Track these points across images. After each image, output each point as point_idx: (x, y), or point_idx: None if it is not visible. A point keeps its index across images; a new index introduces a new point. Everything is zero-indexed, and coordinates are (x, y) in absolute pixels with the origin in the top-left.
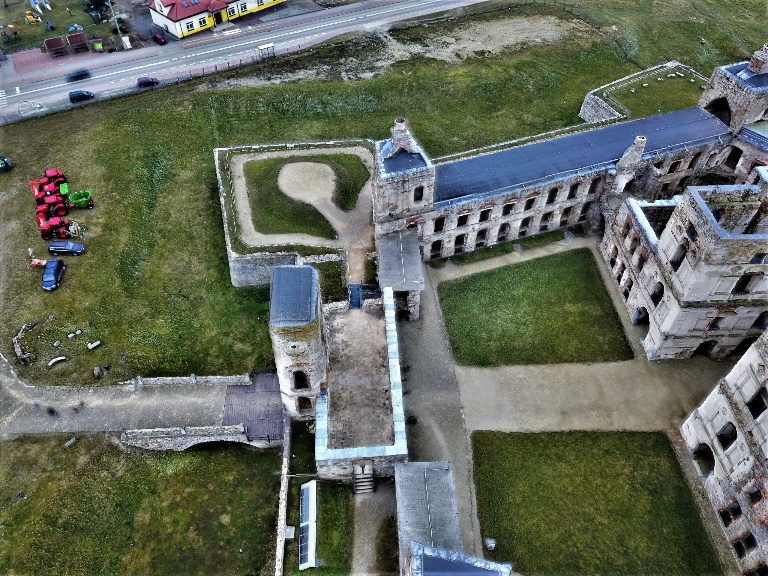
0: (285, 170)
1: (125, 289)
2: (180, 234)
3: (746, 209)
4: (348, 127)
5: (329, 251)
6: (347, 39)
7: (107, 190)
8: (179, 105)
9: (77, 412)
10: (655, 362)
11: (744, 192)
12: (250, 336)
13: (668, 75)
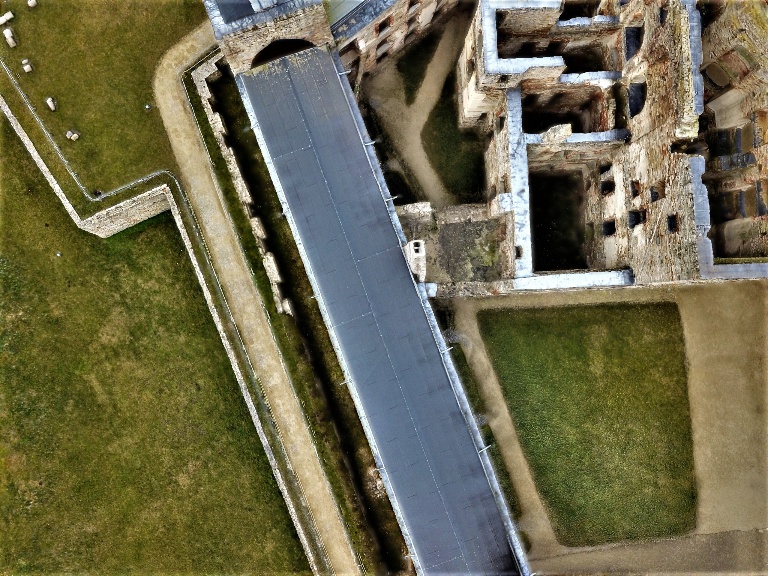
0: None
1: None
2: None
3: None
4: None
5: None
6: None
7: None
8: None
9: None
10: None
11: None
12: None
13: (11, 45)
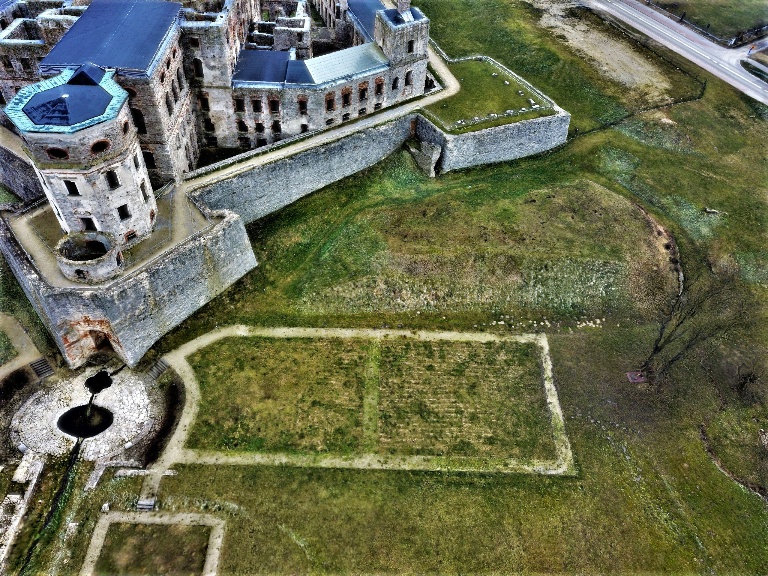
0: None
1: None
2: None
3: None
4: None
5: None
6: None
7: None
8: None
9: None
10: None
11: None
12: None
13: None
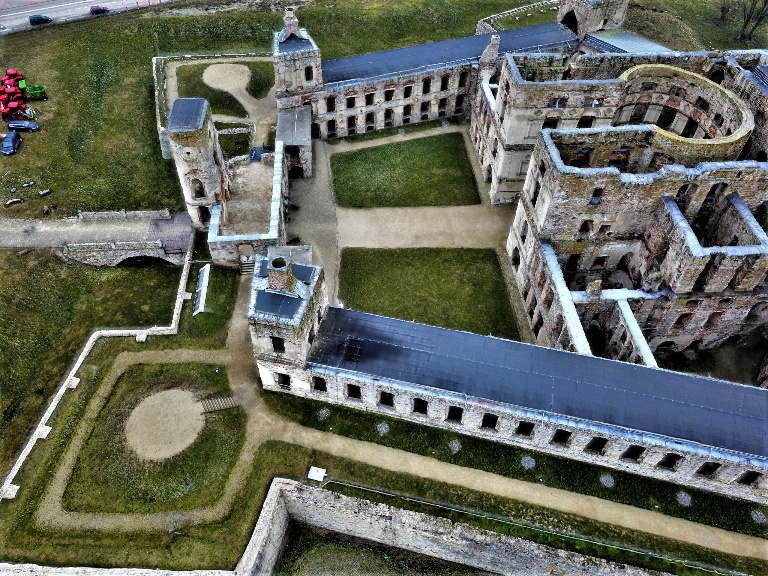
0: (209, 69)
1: (72, 156)
2: (121, 122)
3: (553, 73)
4: None
5: (241, 126)
6: None
7: (60, 88)
8: (126, 28)
9: (29, 235)
10: (497, 206)
11: (550, 59)
12: (175, 194)
13: (550, 8)
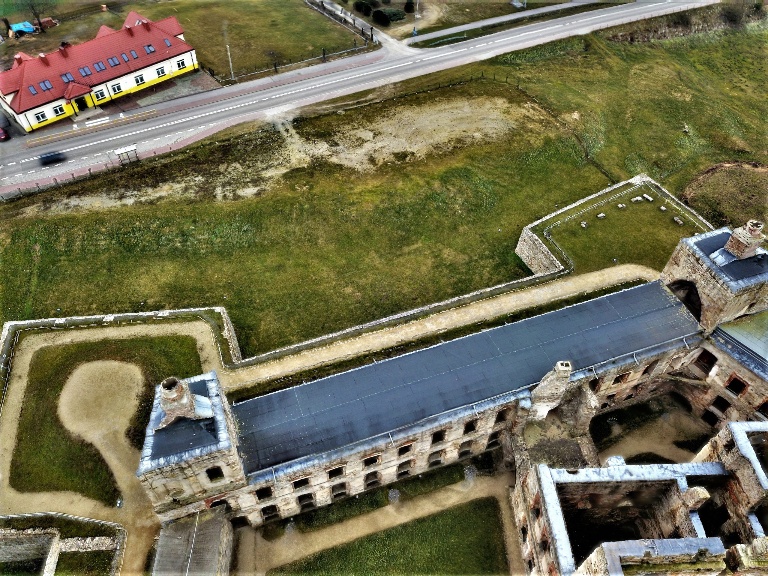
0: (76, 376)
1: None
2: None
3: (702, 571)
4: (210, 271)
5: (102, 530)
6: (237, 134)
7: None
8: None
9: None
10: None
11: (698, 552)
12: None
13: (632, 199)
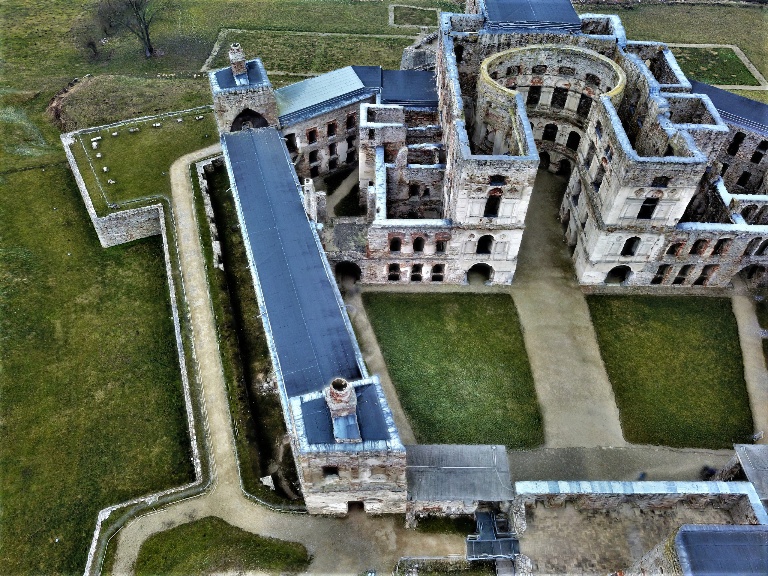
0: None
1: None
2: None
3: None
4: None
5: None
6: None
7: None
8: None
9: None
10: (513, 281)
11: None
12: None
13: (94, 147)
